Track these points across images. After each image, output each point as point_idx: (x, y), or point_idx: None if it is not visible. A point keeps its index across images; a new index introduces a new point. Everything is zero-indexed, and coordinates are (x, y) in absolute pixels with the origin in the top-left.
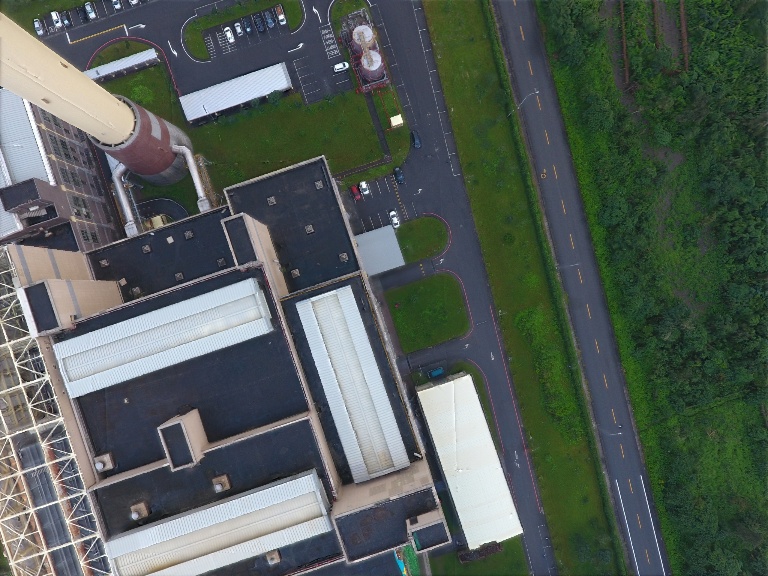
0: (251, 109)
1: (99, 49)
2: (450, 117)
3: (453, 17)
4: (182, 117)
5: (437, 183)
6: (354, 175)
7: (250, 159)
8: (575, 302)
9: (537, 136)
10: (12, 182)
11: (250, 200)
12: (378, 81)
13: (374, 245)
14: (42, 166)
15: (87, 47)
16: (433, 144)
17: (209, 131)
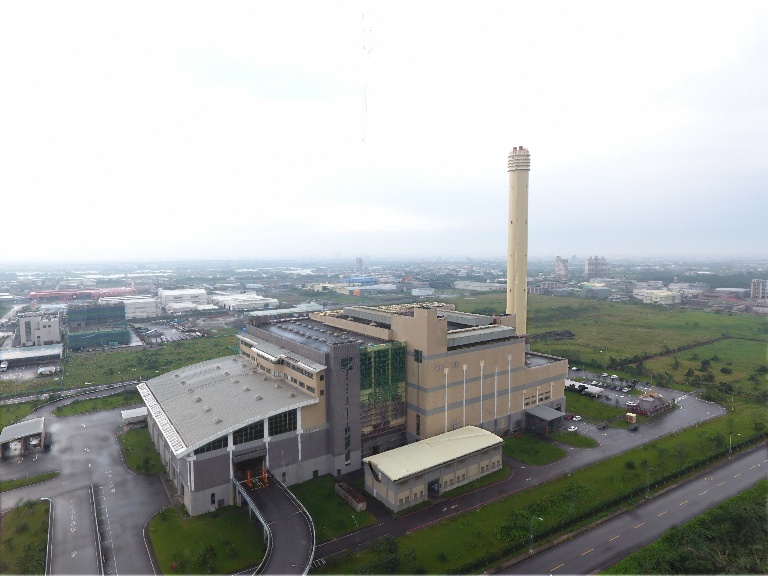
0: None
1: None
2: None
3: None
4: None
5: None
6: None
7: None
8: (635, 515)
9: (729, 471)
10: None
11: None
12: None
13: (546, 410)
14: None
15: None
16: (642, 434)
17: None
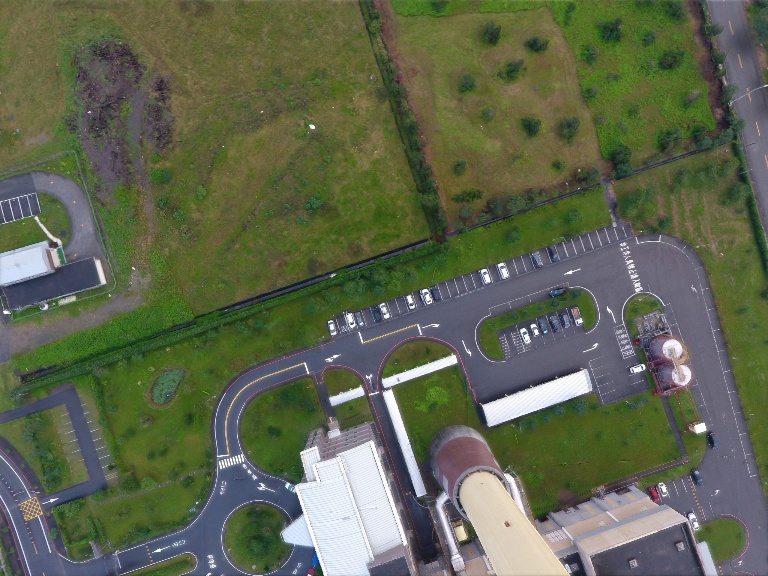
0: (548, 410)
1: (392, 348)
2: (747, 419)
3: (746, 318)
4: (477, 418)
5: (734, 484)
6: (651, 476)
7: (548, 462)
8: None
9: None
10: (371, 549)
11: (611, 562)
12: (679, 387)
13: None
14: (395, 526)
15: (380, 347)
16: (729, 444)
17: (505, 432)
